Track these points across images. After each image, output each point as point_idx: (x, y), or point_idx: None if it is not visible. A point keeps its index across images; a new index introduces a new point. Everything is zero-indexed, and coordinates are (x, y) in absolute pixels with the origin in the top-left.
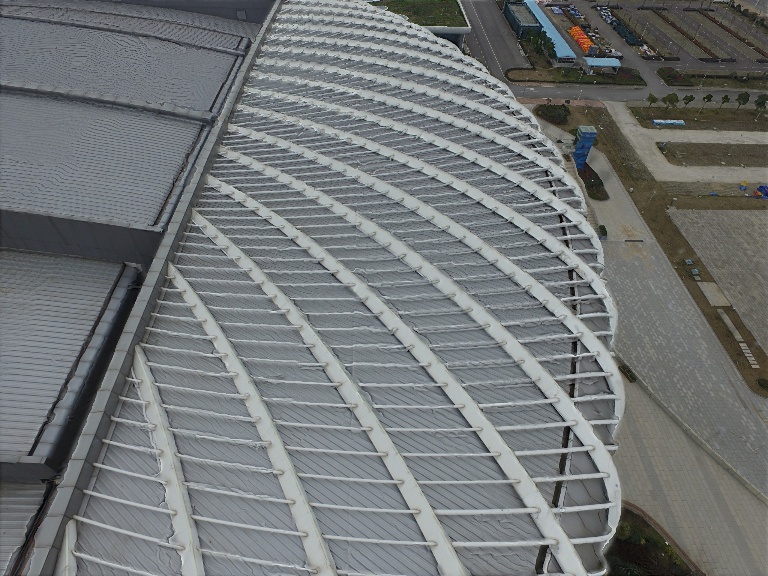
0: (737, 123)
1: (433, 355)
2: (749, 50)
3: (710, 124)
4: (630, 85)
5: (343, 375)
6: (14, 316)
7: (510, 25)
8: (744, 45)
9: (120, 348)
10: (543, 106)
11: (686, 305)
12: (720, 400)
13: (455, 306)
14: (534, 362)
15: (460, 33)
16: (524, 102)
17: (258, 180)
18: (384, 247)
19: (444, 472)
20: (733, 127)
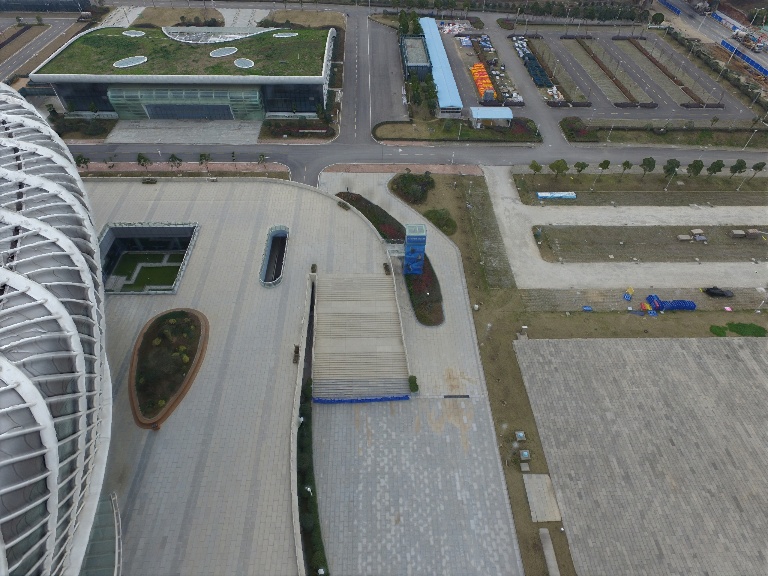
0: (642, 194)
1: None
2: (677, 90)
3: (608, 196)
4: (522, 142)
5: None
6: None
7: (402, 62)
8: (672, 84)
9: None
10: (402, 177)
11: (497, 520)
12: None
13: None
14: None
15: (312, 83)
16: (382, 170)
17: None
18: None
19: None
20: (636, 200)
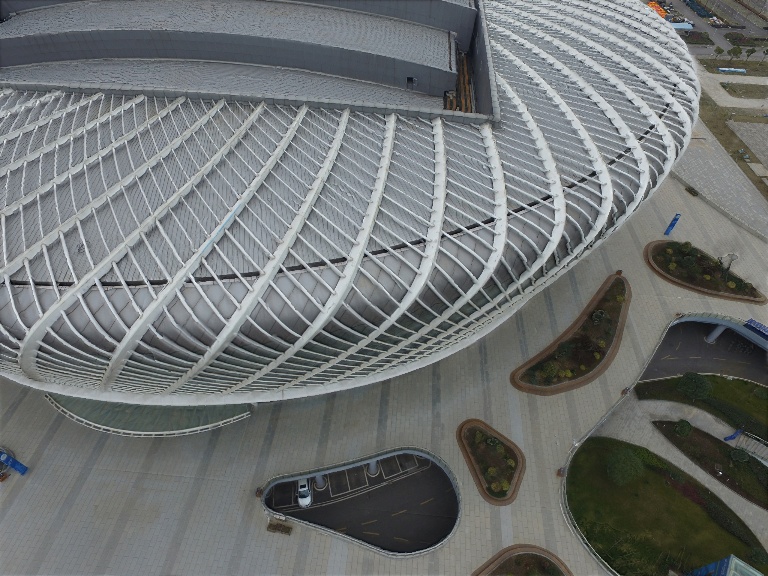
0: None
1: (614, 53)
2: None
3: None
4: (700, 44)
5: (577, 52)
6: (417, 39)
7: None
8: None
9: (486, 34)
10: None
11: (737, 174)
12: (758, 222)
13: (618, 47)
14: (659, 63)
15: None
16: None
17: (508, 2)
18: (579, 28)
19: (626, 78)
20: None
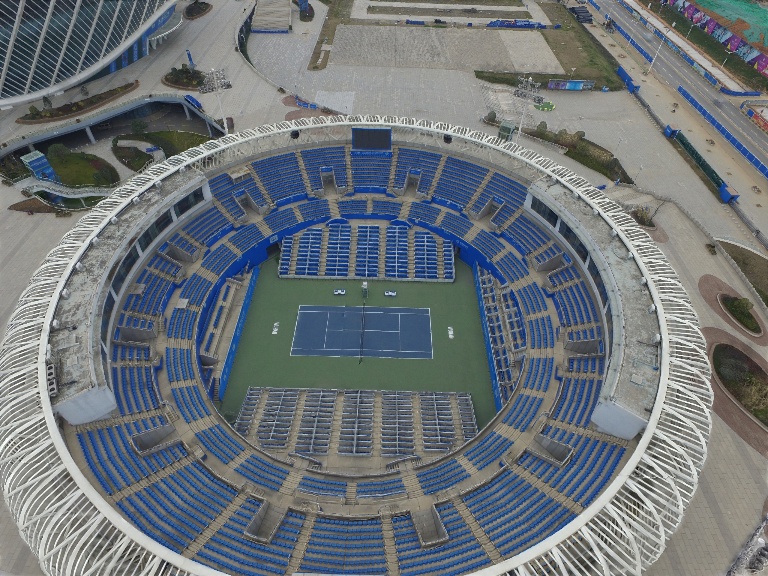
0: (433, 0)
1: None
2: None
3: (414, 0)
4: None
5: None
6: None
7: None
8: None
9: None
10: None
11: (308, 50)
12: None
13: None
14: None
15: None
16: None
17: None
18: None
19: None
20: (428, 2)
